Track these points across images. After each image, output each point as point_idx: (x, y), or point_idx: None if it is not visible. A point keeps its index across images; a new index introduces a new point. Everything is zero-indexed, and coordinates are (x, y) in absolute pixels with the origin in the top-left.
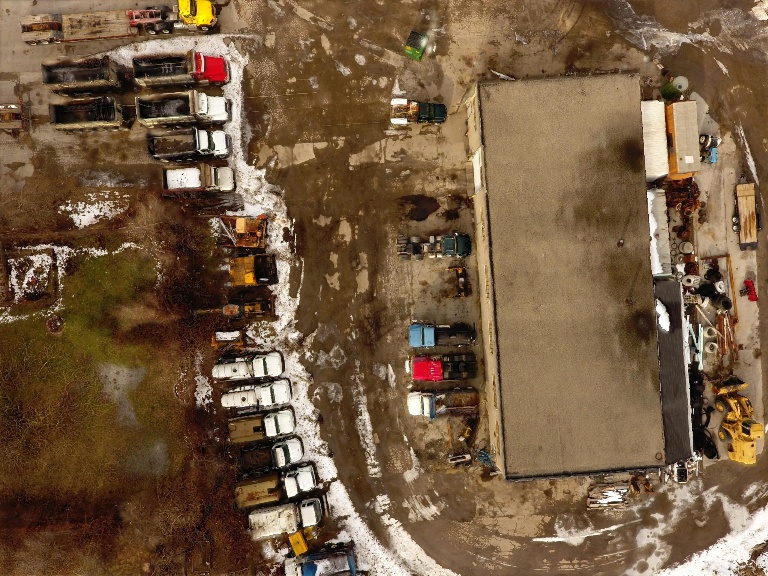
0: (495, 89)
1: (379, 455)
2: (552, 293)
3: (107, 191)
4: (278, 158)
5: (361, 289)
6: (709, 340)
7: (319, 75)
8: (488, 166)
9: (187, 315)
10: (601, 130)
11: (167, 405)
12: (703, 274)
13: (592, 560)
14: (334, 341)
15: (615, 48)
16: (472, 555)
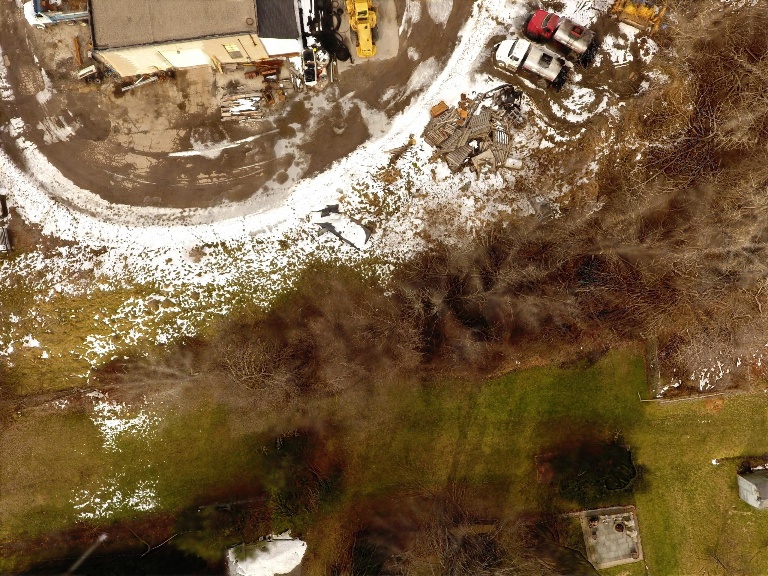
0: None
1: (11, 78)
2: None
3: None
4: None
5: None
6: None
7: None
8: None
9: None
10: None
11: None
12: None
13: (230, 173)
14: None
15: None
16: (109, 174)
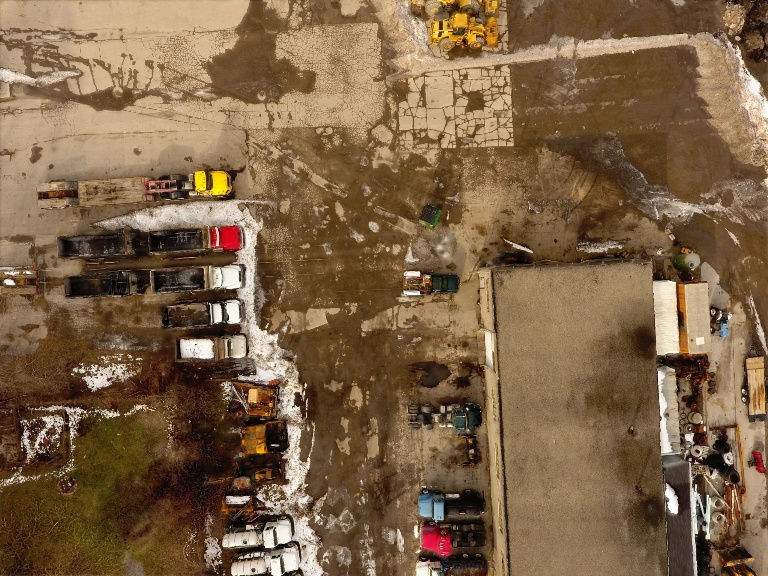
0: (508, 276)
1: None
2: (562, 479)
3: (120, 354)
4: (291, 323)
5: (371, 454)
6: (716, 510)
7: (333, 242)
8: (500, 352)
9: (198, 480)
10: (613, 317)
11: (177, 566)
12: (711, 444)
13: None
14: (344, 505)
15: (627, 218)
16: None
